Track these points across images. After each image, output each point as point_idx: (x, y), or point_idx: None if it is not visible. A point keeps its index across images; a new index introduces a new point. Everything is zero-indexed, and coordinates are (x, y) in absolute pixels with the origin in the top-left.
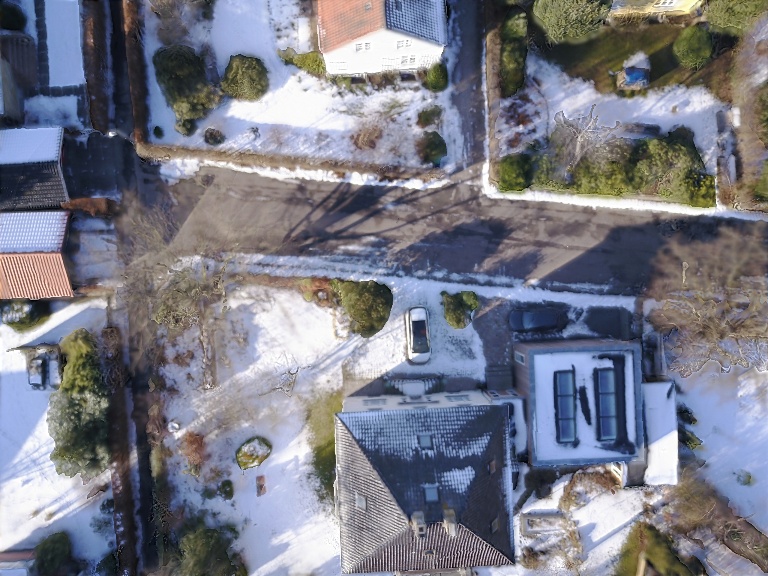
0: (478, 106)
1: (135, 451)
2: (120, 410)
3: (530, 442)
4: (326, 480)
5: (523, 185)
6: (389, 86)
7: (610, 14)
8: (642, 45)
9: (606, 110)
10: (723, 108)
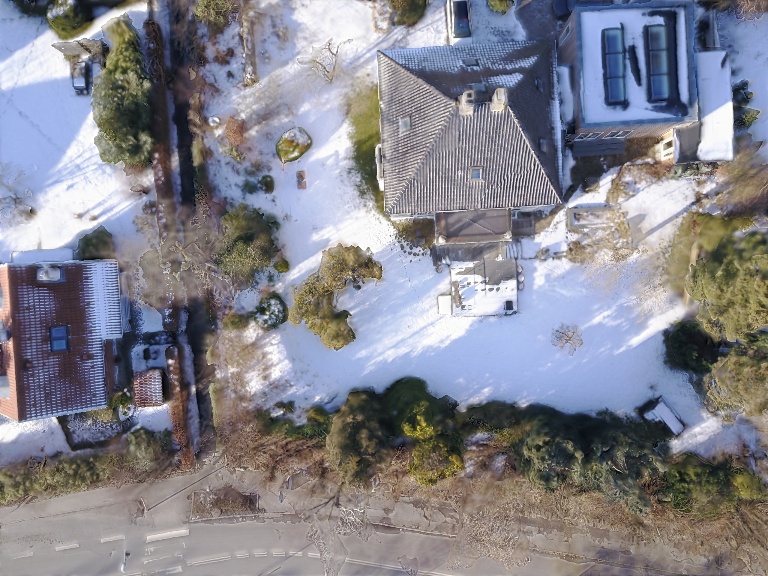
0: None
1: (176, 154)
2: (162, 104)
3: (577, 104)
4: (367, 175)
5: None
6: None
7: None
8: None
9: None
10: None
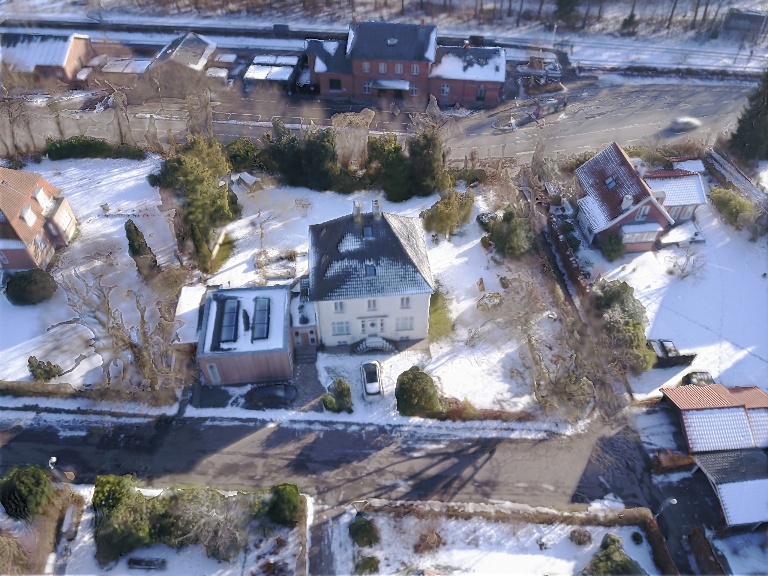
0: None
1: (577, 306)
2: None
3: None
4: None
5: None
6: None
7: None
8: None
9: None
10: None
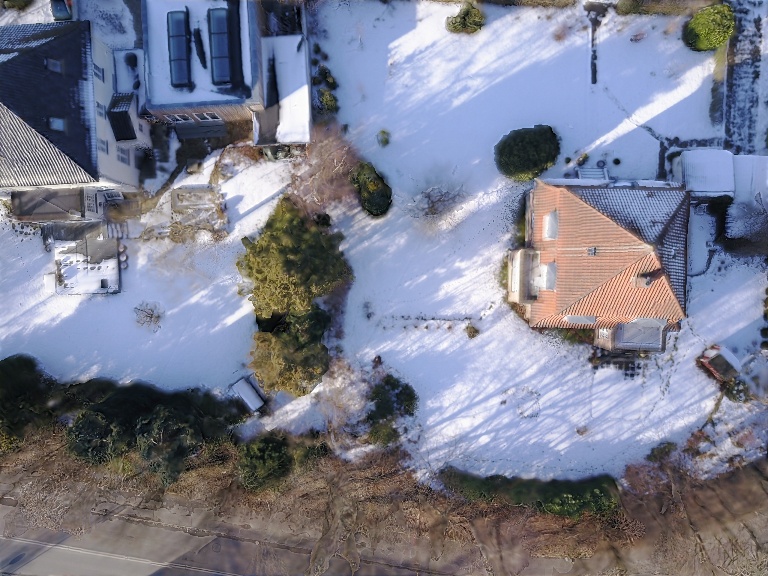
0: None
1: None
2: None
3: None
4: None
5: None
6: None
7: None
8: None
9: None
10: None
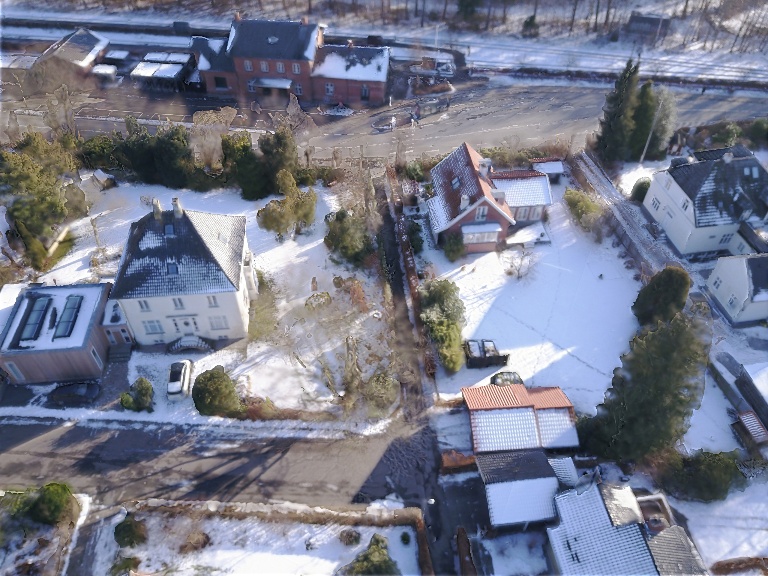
0: None
1: (409, 306)
2: None
3: None
4: (267, 290)
5: None
6: None
7: None
8: None
9: None
10: None
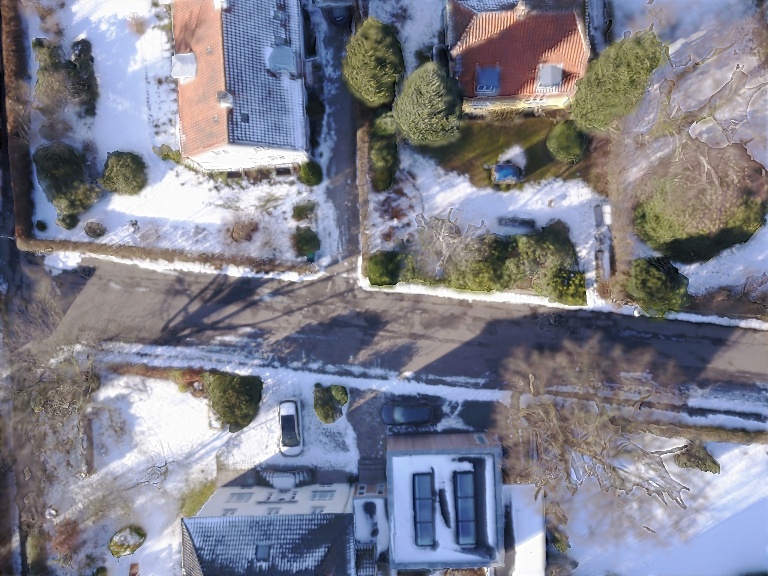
0: (353, 199)
1: (18, 534)
2: None
3: (389, 544)
4: None
5: (389, 283)
6: (264, 180)
7: (484, 108)
8: (517, 139)
9: (481, 204)
10: (600, 202)
